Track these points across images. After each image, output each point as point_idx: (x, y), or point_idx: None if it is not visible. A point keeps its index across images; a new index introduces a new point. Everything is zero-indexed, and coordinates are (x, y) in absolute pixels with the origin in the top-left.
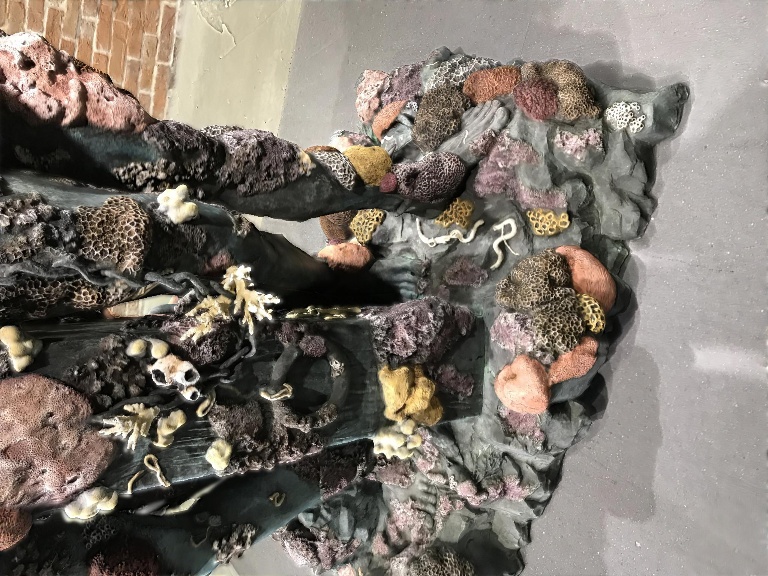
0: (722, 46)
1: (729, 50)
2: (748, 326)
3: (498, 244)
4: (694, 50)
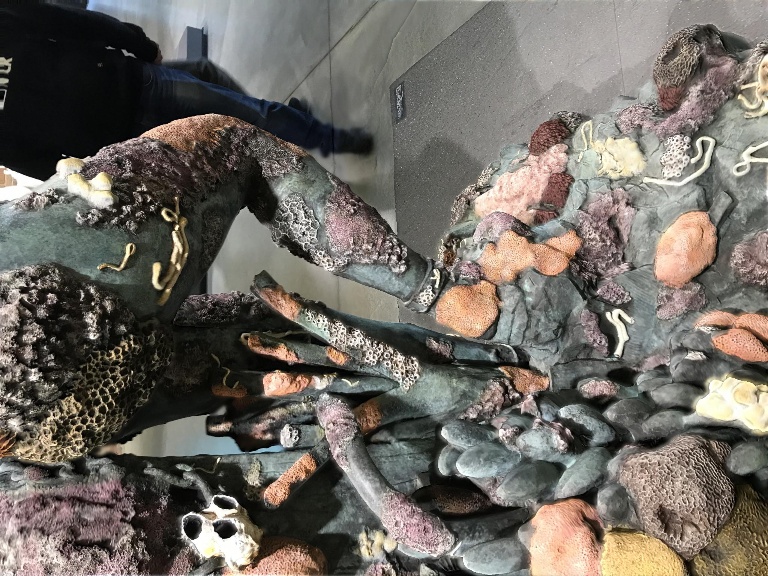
0: None
1: None
2: None
3: None
4: None
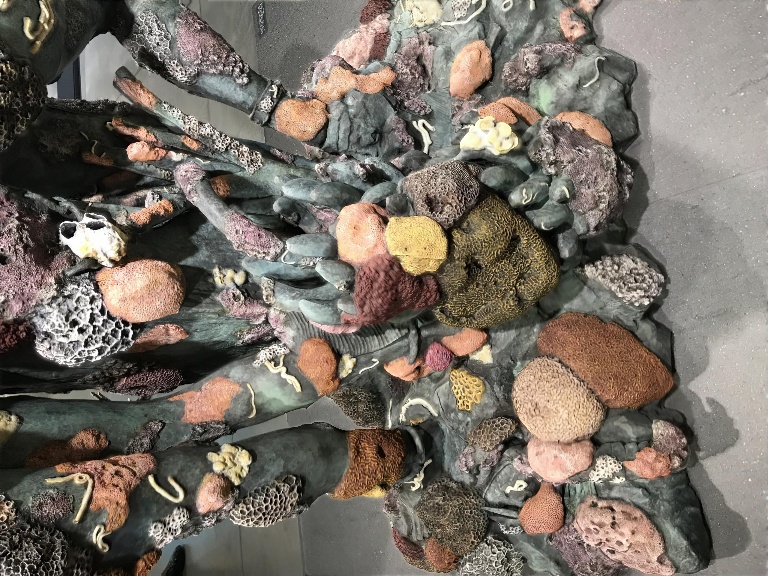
0: (404, 575)
1: (400, 572)
2: (343, 417)
3: (389, 421)
4: (414, 573)
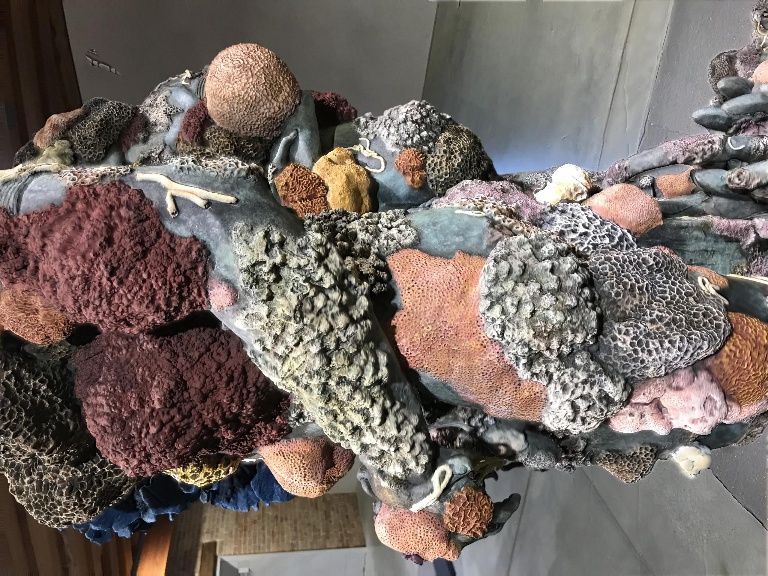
0: None
1: None
2: None
3: None
4: None
